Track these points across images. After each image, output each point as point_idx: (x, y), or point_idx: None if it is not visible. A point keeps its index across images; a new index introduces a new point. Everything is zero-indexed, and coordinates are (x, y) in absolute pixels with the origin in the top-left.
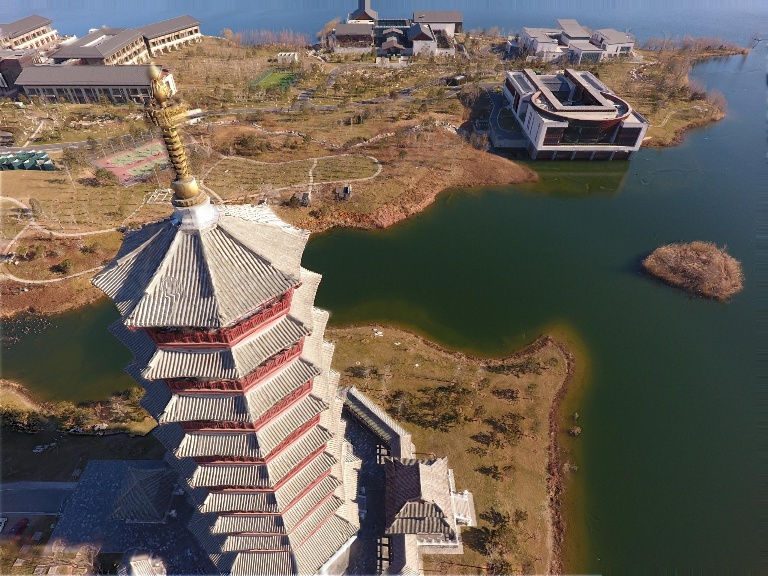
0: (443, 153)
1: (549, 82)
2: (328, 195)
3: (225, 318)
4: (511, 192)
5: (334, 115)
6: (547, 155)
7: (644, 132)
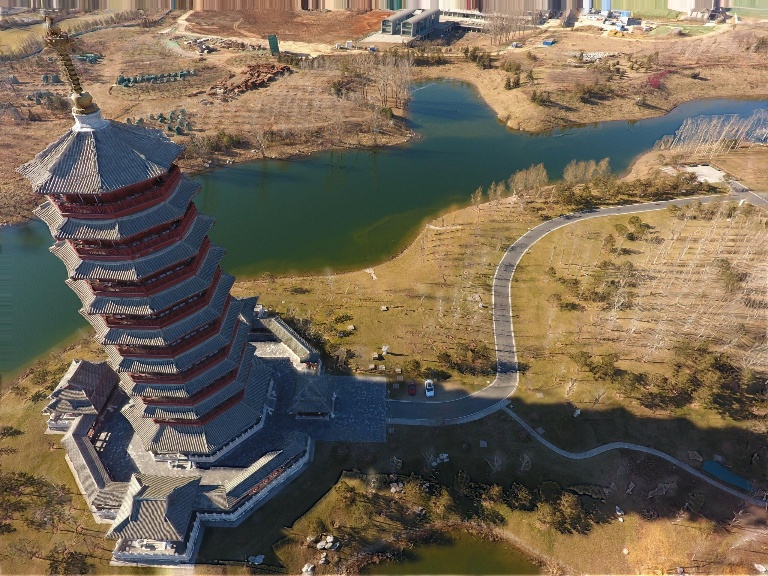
0: None
1: None
2: None
3: None
4: None
5: None
6: None
7: None
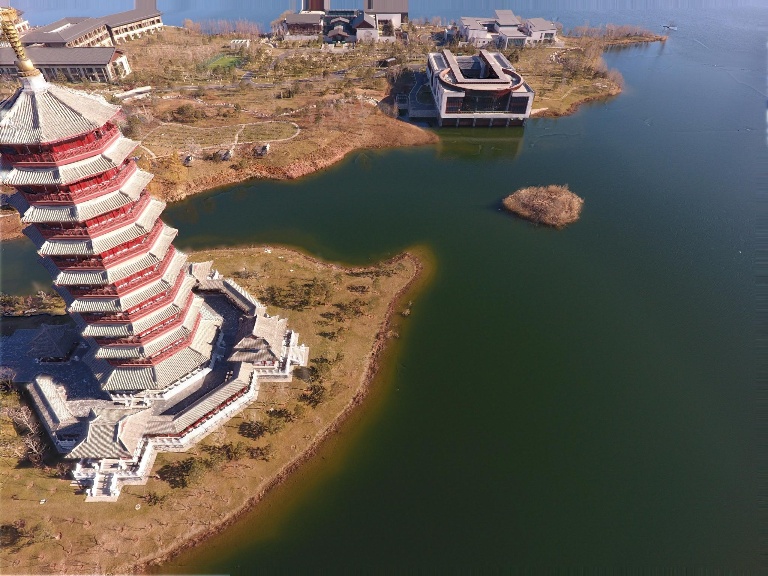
0: (358, 120)
1: (463, 61)
2: (247, 152)
3: (45, 138)
4: (412, 152)
5: (270, 91)
6: (452, 123)
7: (531, 101)
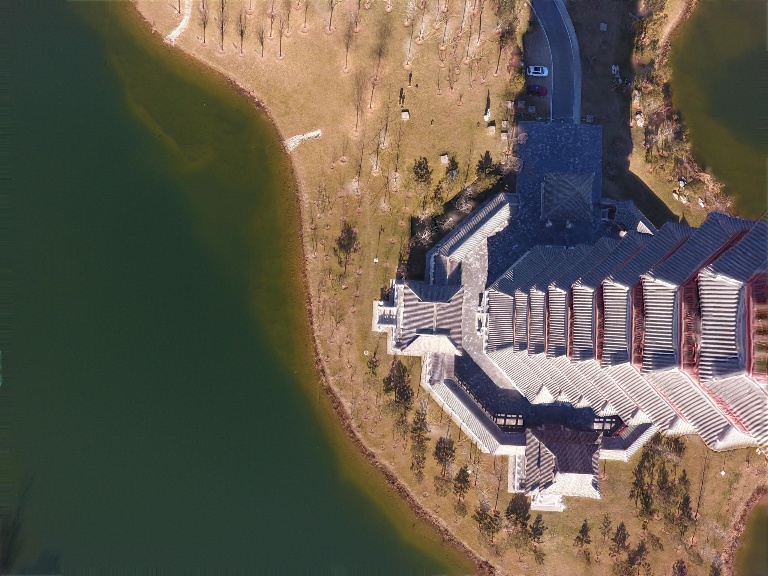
0: None
1: None
2: None
3: None
4: None
5: None
6: None
7: None
